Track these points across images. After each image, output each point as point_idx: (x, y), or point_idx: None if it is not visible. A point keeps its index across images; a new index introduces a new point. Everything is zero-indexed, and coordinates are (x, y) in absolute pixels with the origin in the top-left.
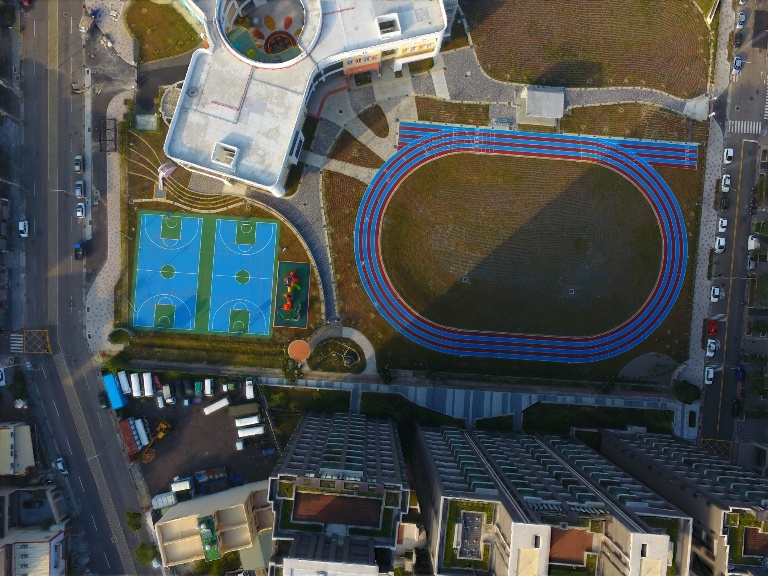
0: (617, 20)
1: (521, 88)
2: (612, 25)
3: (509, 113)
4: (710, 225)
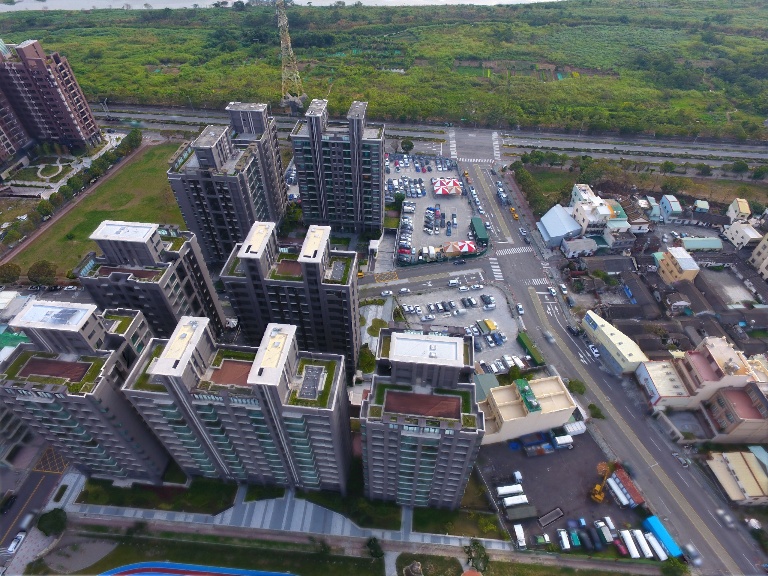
0: None
1: None
2: None
3: None
4: None
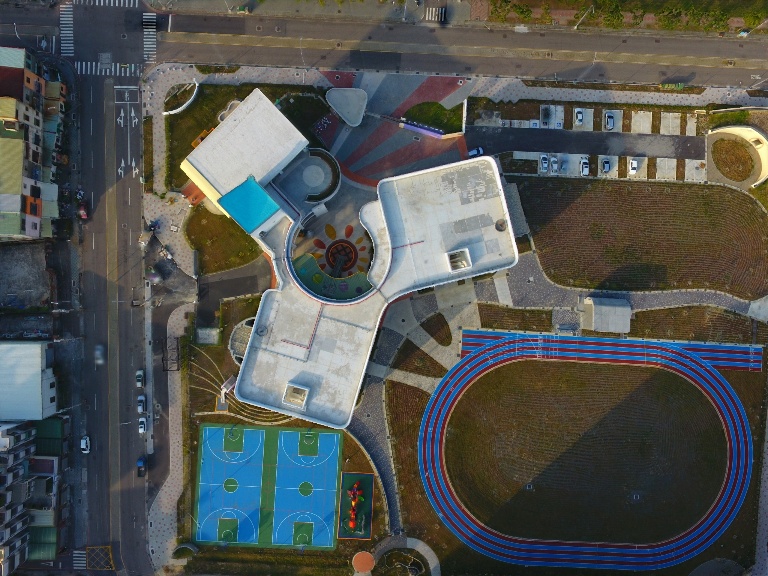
0: (680, 222)
1: (584, 293)
2: (675, 227)
3: (572, 318)
4: None
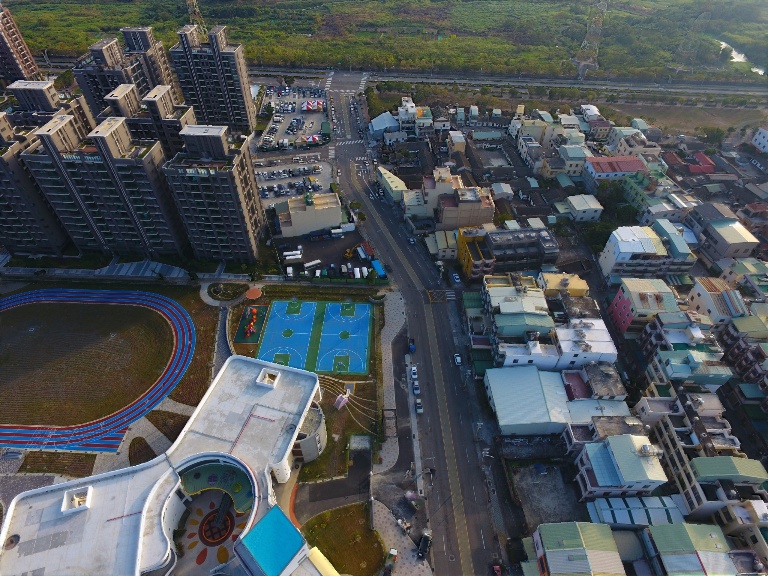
0: None
1: None
2: None
3: (1, 465)
4: None
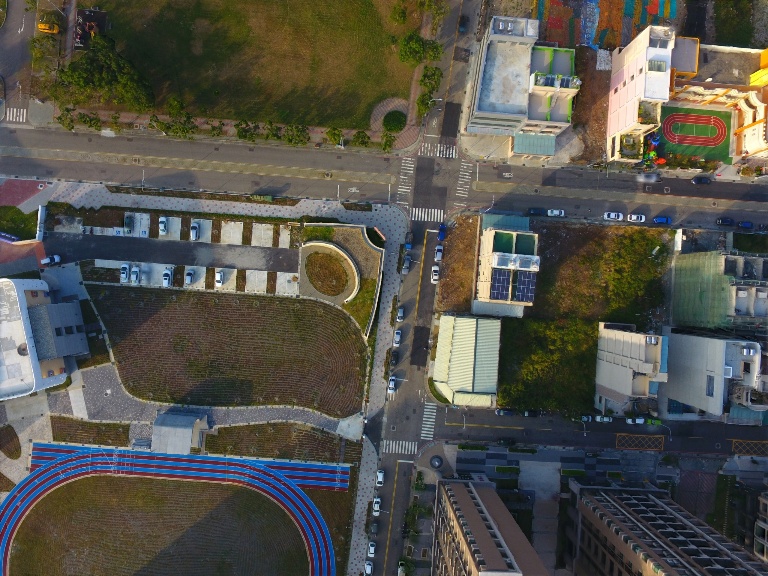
0: (269, 336)
1: (164, 407)
2: (263, 341)
3: (151, 433)
4: (360, 549)
